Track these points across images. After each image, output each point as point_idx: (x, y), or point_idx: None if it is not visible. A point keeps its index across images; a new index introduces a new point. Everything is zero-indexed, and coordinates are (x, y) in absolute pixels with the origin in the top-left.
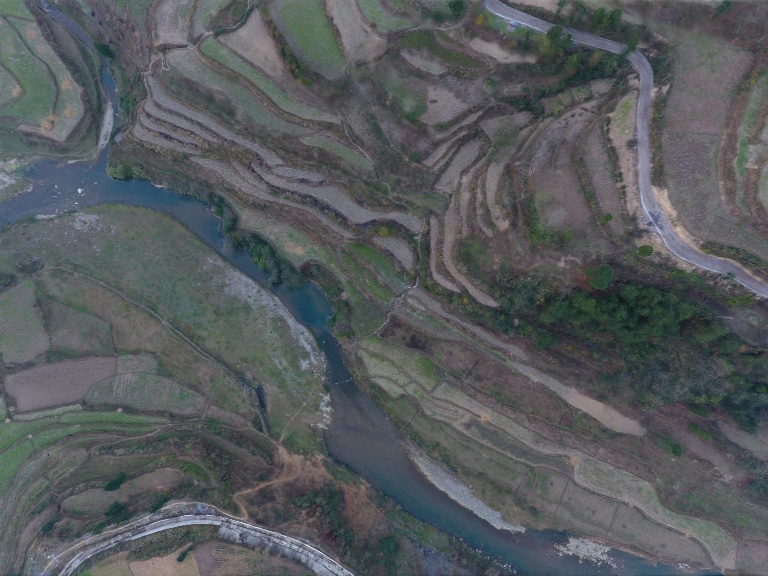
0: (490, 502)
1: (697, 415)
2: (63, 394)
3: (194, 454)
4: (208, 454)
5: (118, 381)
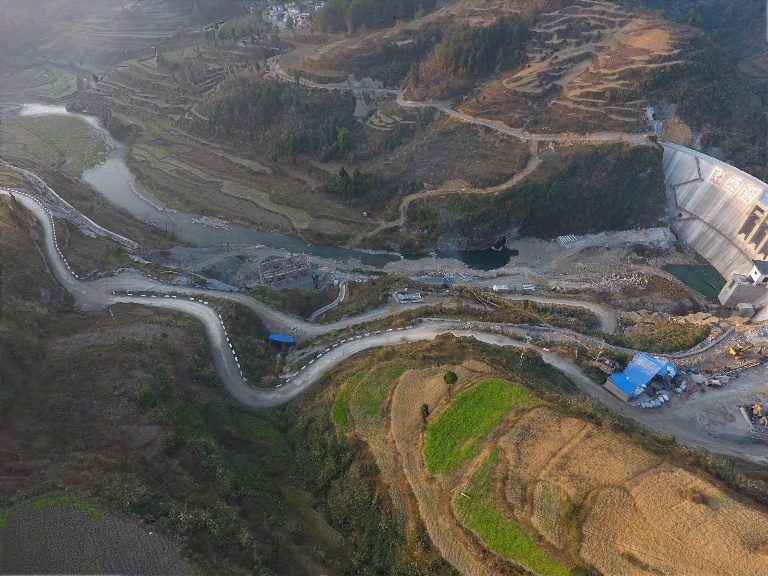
0: (163, 199)
1: (299, 159)
2: None
3: None
4: None
5: None
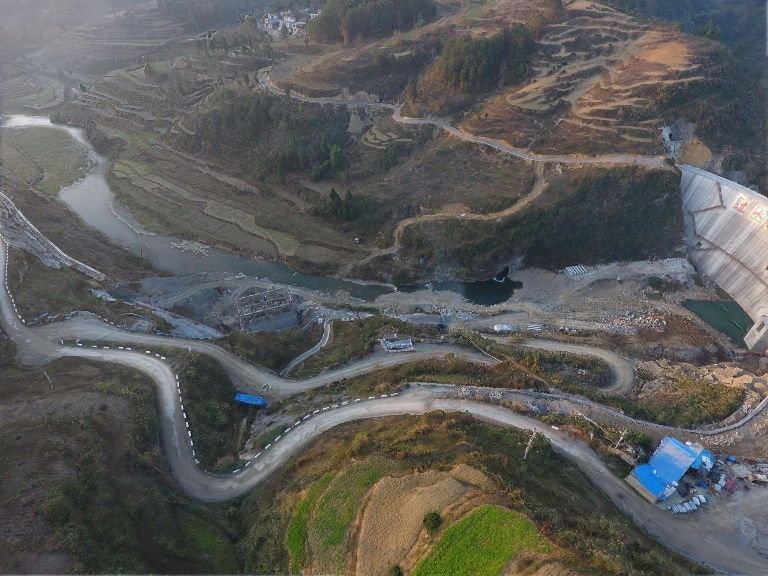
0: None
1: (288, 178)
2: None
3: None
4: None
5: None
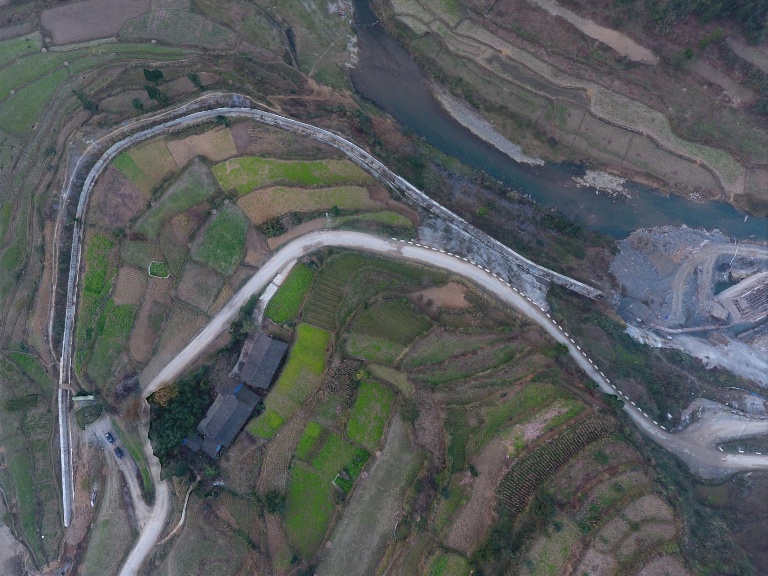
0: (511, 136)
1: (707, 34)
2: (98, 29)
3: (228, 67)
4: (241, 70)
5: (152, 17)
